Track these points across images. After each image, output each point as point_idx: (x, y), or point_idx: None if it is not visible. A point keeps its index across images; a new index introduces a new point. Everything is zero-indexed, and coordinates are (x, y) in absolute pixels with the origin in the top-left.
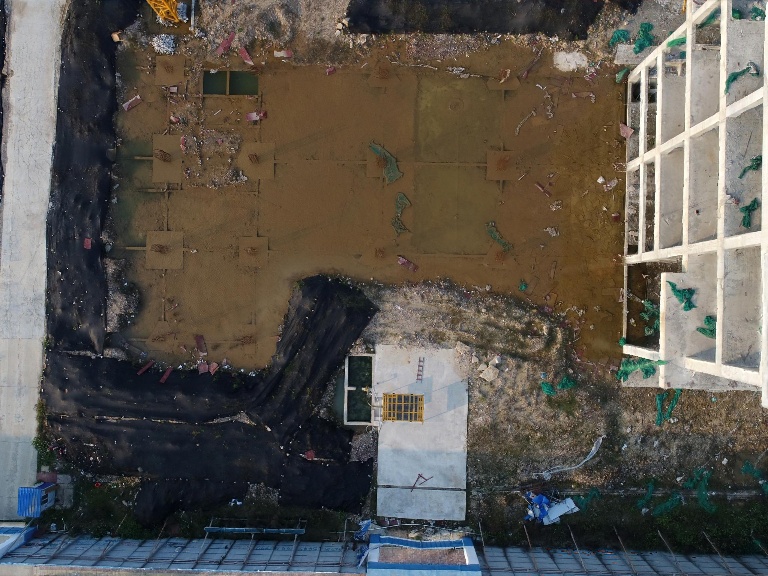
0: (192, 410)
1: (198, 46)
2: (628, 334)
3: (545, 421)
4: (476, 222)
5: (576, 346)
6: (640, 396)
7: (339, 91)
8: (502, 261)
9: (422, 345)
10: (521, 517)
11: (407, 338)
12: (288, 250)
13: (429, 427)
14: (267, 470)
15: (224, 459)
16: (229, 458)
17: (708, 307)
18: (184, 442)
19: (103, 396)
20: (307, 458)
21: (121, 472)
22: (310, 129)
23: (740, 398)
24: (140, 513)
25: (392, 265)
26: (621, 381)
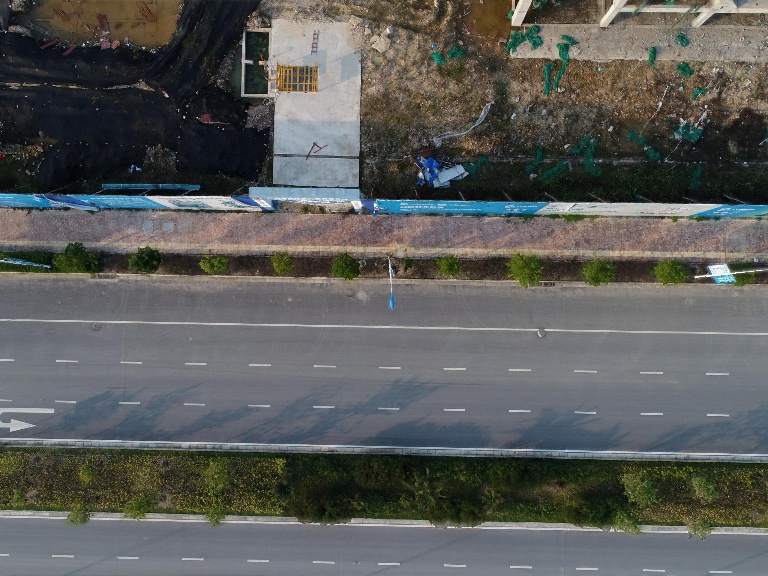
0: (92, 77)
1: None
2: None
3: (436, 89)
4: None
5: (466, 20)
6: (528, 67)
7: None
8: None
9: (317, 19)
10: (413, 183)
11: (302, 12)
12: None
13: (323, 97)
14: (164, 131)
15: (123, 123)
16: (127, 122)
17: None
18: (84, 106)
19: (6, 64)
20: (203, 121)
21: (23, 139)
22: None
23: (625, 67)
24: (42, 178)
25: None
26: (510, 53)
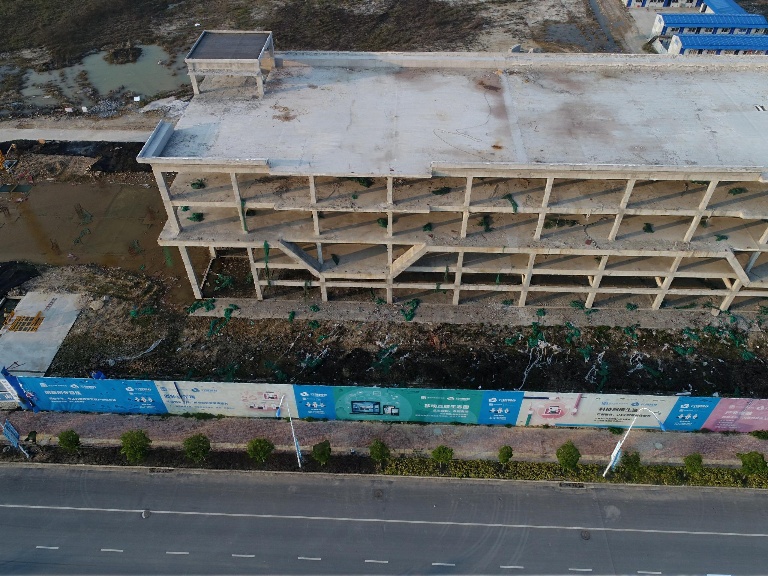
0: None
1: (7, 176)
2: (203, 290)
3: (125, 331)
4: (127, 241)
5: (165, 296)
6: (200, 321)
7: (74, 192)
8: (134, 256)
9: (59, 292)
10: None
11: (51, 288)
12: (1, 251)
13: (39, 335)
14: None
15: None
16: None
17: (197, 210)
18: None
19: None
20: None
21: None
22: (49, 205)
23: (271, 323)
24: None
25: (63, 258)
26: (189, 313)
